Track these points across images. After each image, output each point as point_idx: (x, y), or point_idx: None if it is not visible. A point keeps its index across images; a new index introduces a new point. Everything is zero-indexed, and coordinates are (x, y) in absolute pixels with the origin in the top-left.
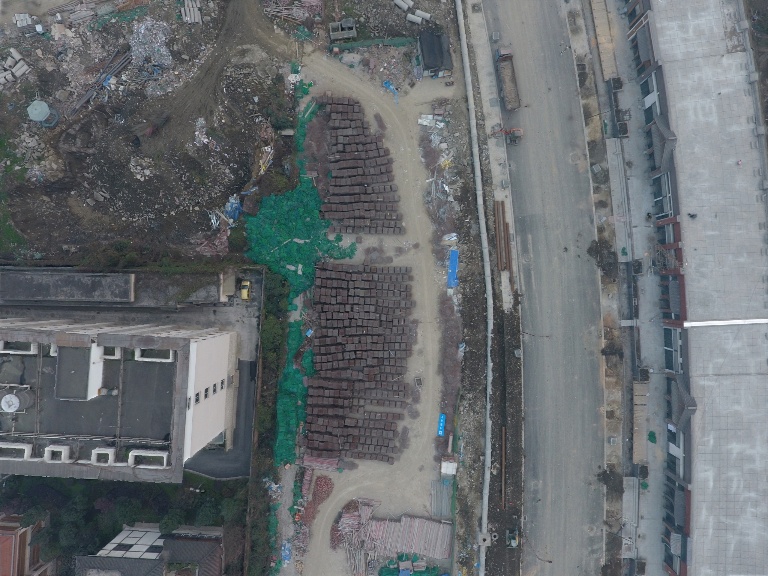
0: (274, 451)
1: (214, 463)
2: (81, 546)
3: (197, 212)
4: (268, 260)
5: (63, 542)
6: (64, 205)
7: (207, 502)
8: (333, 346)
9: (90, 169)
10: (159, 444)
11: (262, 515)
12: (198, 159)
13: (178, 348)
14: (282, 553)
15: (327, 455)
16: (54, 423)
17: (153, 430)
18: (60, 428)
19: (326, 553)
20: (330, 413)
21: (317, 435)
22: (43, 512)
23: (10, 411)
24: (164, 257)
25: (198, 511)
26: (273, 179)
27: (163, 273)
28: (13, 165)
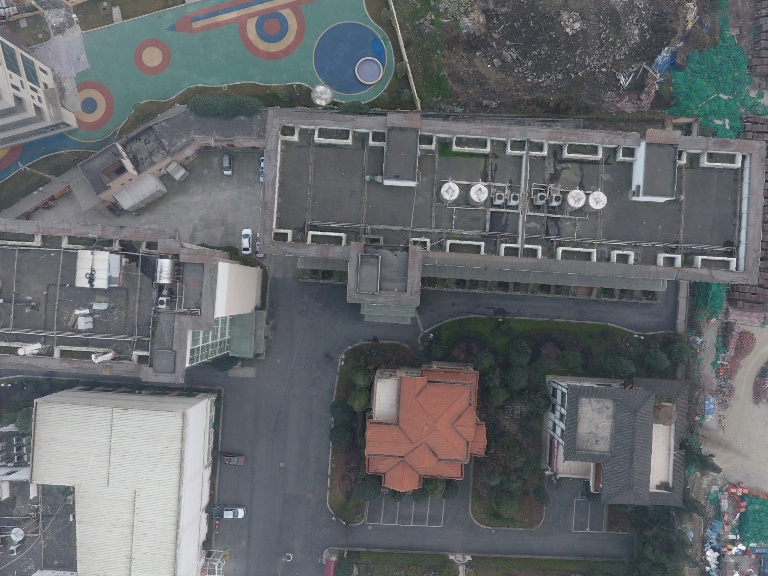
0: (701, 305)
1: (637, 318)
2: (527, 391)
3: (603, 73)
4: (696, 114)
5: (522, 383)
6: (472, 65)
7: (655, 348)
8: (765, 199)
9: (496, 30)
10: (721, 250)
11: (691, 368)
12: (621, 15)
13: (754, 150)
14: (706, 407)
15: (758, 307)
16: (613, 230)
17: (712, 237)
18: (619, 235)
19: (749, 408)
20: (762, 265)
21: (749, 287)
22: (493, 356)
23: (598, 208)
24: (595, 110)
25: (647, 356)
26: (701, 34)
27: (608, 121)
28: (437, 19)
